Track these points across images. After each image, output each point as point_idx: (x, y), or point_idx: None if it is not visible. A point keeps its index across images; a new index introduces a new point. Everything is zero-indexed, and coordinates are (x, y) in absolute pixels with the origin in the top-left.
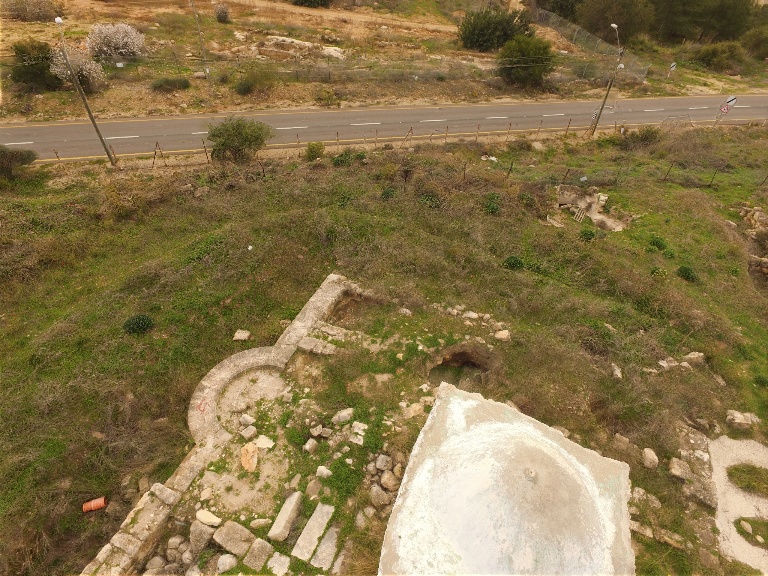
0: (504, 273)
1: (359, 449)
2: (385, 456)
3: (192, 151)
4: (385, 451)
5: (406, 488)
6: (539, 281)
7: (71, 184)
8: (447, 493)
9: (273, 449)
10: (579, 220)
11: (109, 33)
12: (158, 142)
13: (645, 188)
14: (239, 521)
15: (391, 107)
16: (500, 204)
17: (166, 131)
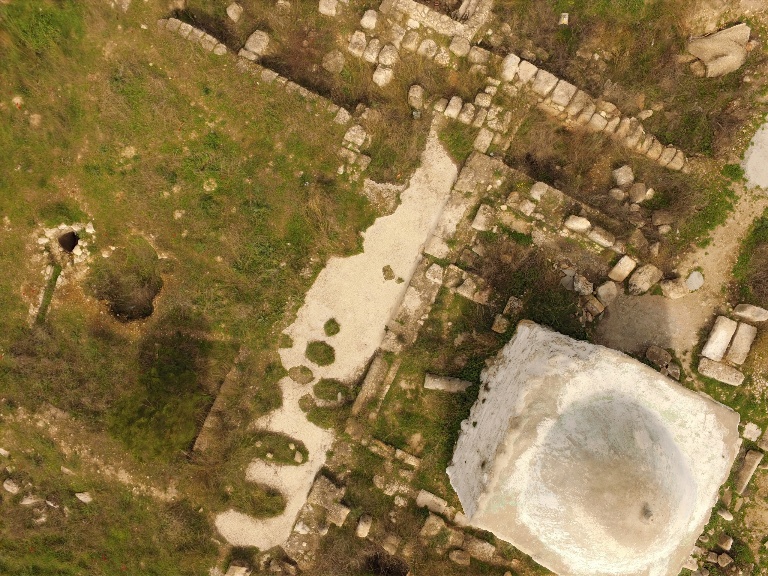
0: None
1: None
2: None
3: None
4: None
5: None
6: None
7: None
8: None
9: (765, 538)
10: None
11: None
12: None
13: None
14: None
15: None
16: None
17: None
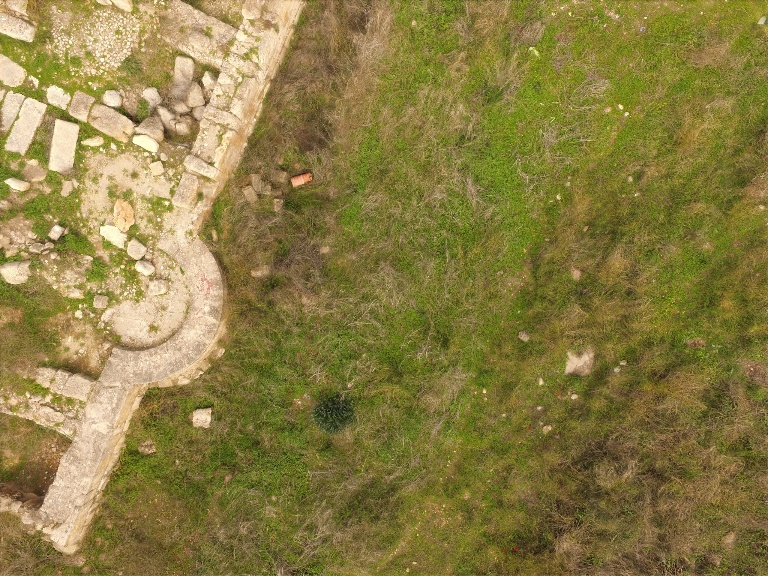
0: None
1: None
2: None
3: None
4: None
5: None
6: None
7: None
8: None
9: None
10: None
11: None
12: None
13: None
14: (114, 142)
15: None
16: None
17: None
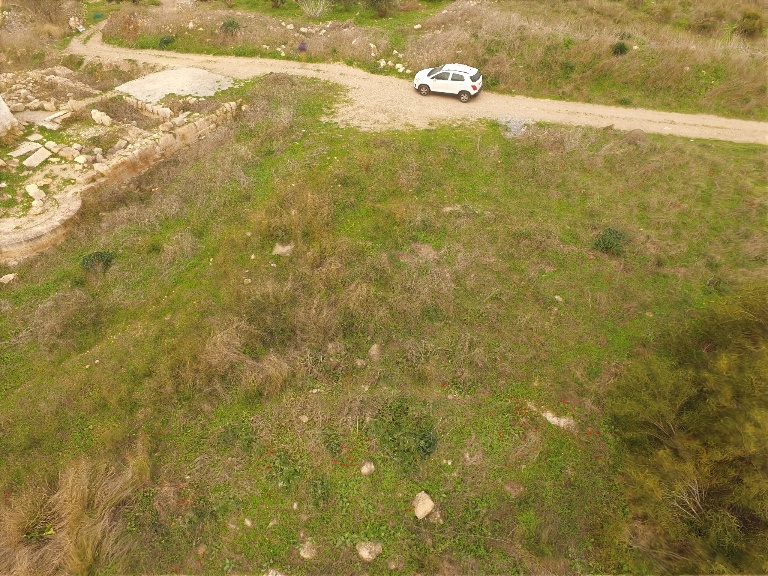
0: None
1: None
2: None
3: None
4: None
5: None
6: None
7: None
8: None
9: None
10: None
11: None
12: None
13: None
14: (65, 160)
15: None
16: None
17: None
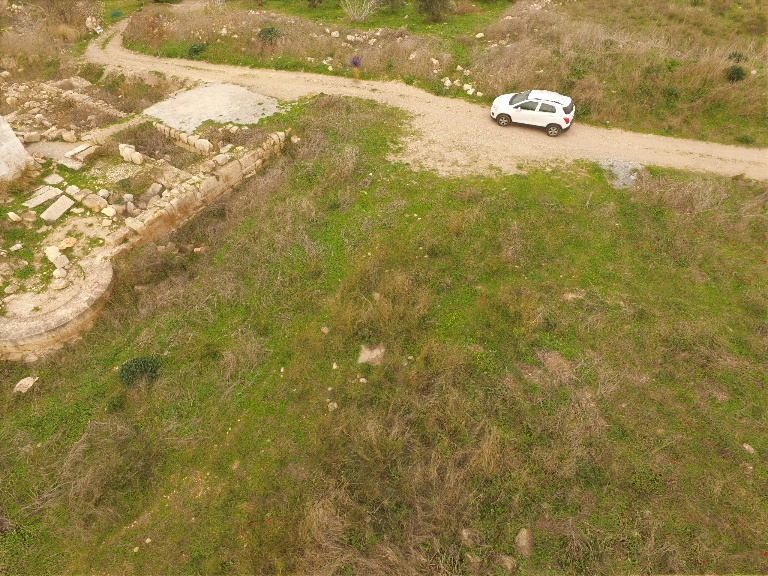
0: None
1: None
2: None
3: None
4: None
5: None
6: None
7: None
8: None
9: None
10: None
11: None
12: None
13: None
14: (90, 211)
15: None
16: None
17: None
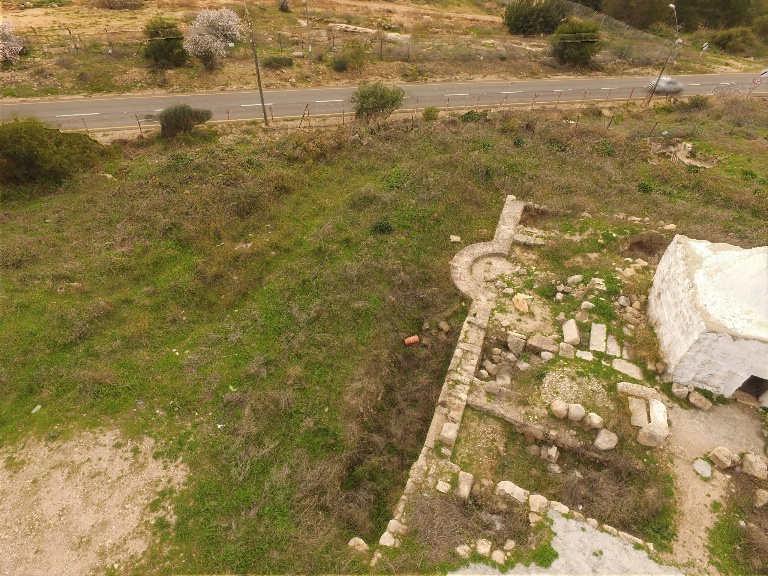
0: (639, 195)
1: (604, 293)
2: (625, 297)
3: (325, 115)
4: (622, 295)
5: (693, 283)
6: (668, 200)
7: (239, 140)
8: (730, 279)
9: (534, 300)
10: (675, 162)
11: (215, 17)
12: (308, 104)
13: (720, 138)
14: None
15: (470, 82)
16: (612, 149)
17: (293, 100)
